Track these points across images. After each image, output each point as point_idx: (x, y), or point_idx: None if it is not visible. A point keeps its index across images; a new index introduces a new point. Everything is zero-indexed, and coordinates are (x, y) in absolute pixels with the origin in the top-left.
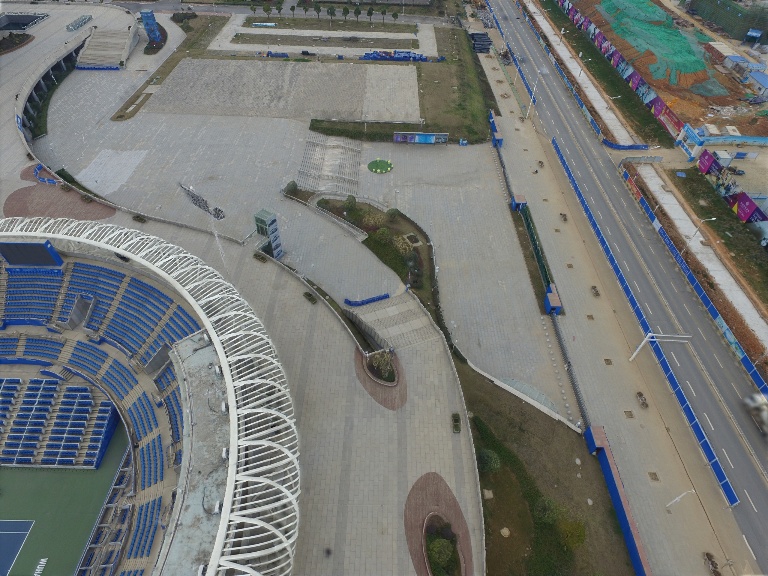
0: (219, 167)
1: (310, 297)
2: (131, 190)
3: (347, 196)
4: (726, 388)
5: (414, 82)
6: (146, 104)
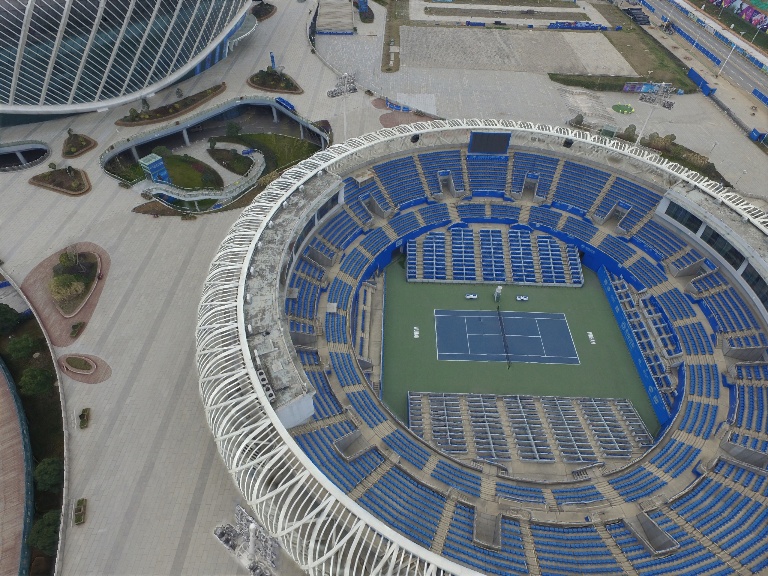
0: (502, 106)
1: None
2: None
3: None
4: None
5: (611, 46)
6: (402, 60)
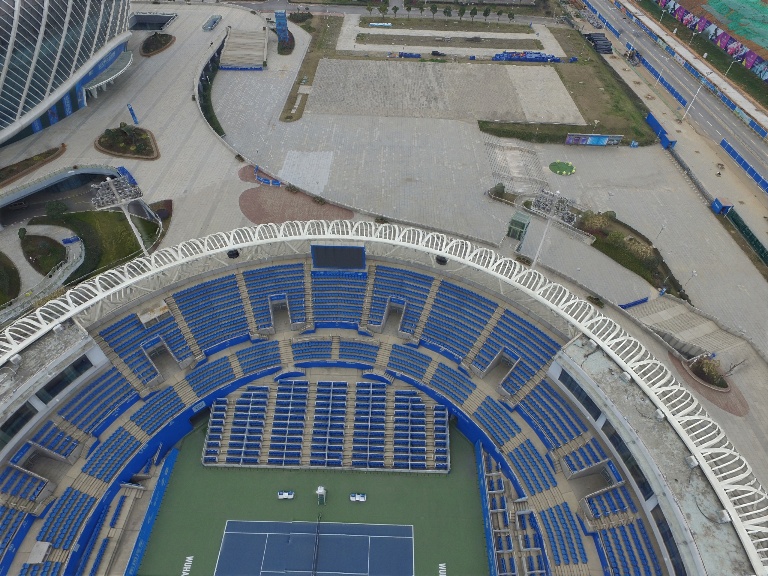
0: (411, 169)
1: (598, 301)
2: (337, 192)
3: None
4: None
5: (560, 83)
6: (308, 105)
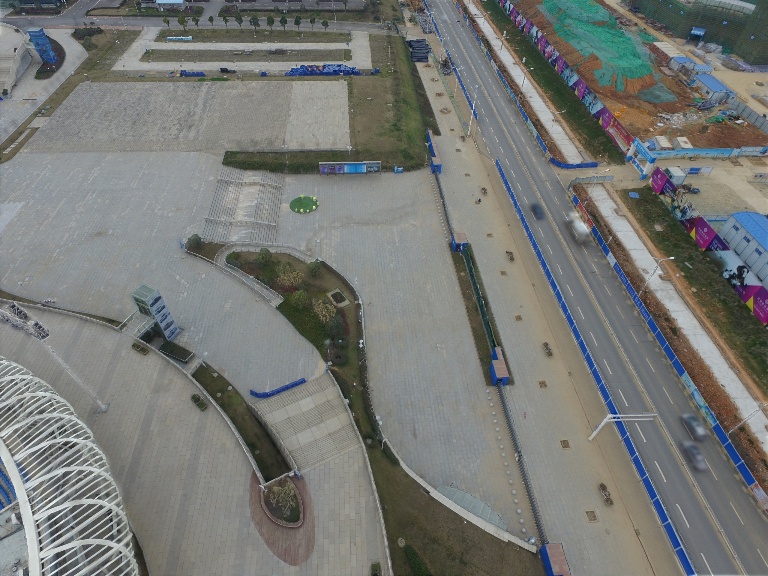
0: (110, 219)
1: (198, 402)
2: None
3: (263, 246)
4: (699, 467)
5: (344, 100)
6: (29, 142)
